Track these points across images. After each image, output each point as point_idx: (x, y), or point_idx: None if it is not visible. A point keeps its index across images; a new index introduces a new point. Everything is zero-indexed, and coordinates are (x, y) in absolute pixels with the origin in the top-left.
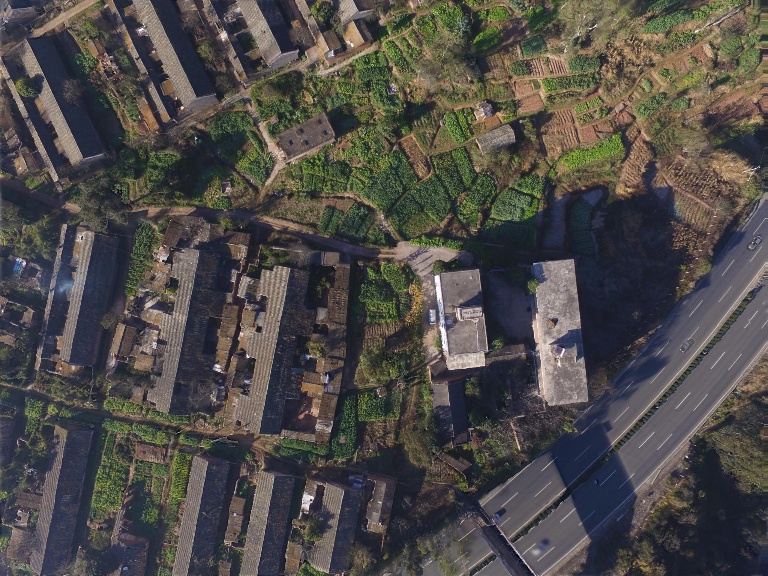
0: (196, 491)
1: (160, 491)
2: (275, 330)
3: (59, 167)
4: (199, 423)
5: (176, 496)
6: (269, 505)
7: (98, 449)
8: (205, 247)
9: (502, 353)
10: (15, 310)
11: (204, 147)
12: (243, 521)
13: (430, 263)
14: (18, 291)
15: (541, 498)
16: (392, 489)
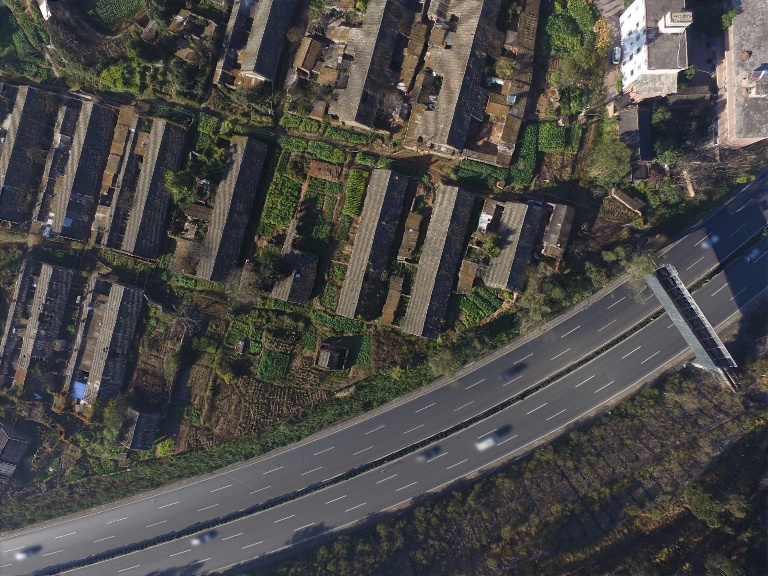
0: (376, 201)
1: (332, 209)
2: (468, 43)
3: None
4: (376, 143)
5: (350, 212)
6: (451, 216)
7: (271, 166)
8: None
9: (686, 92)
10: (197, 24)
11: None
12: (418, 238)
13: (615, 5)
14: (199, 7)
15: (693, 272)
16: (572, 213)
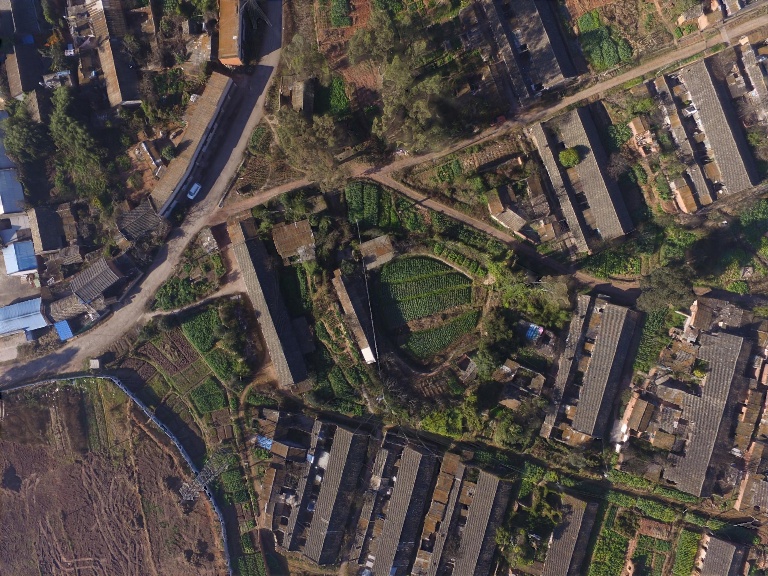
0: (717, 573)
1: (661, 567)
2: None
3: (590, 239)
4: (706, 503)
5: (683, 574)
6: None
7: (599, 520)
8: (736, 332)
9: None
10: (524, 375)
11: (728, 230)
12: None
13: None
14: (524, 356)
15: None
16: None
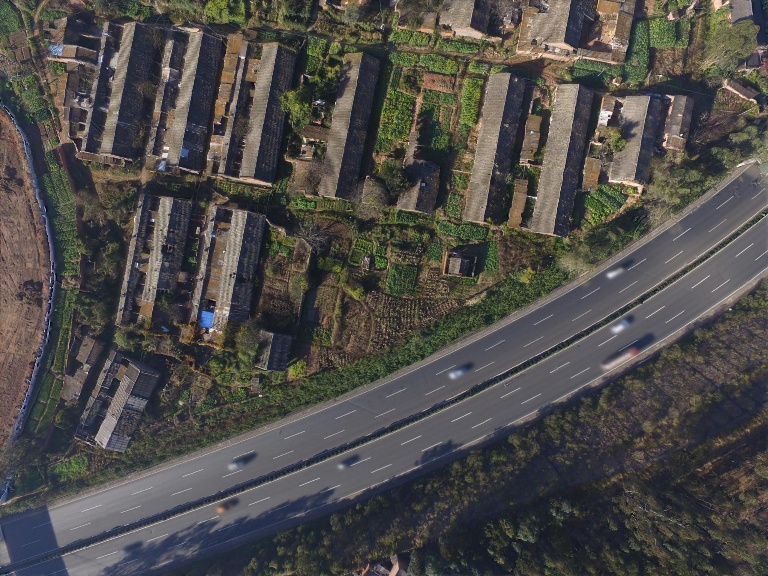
0: (496, 105)
1: (449, 120)
2: None
3: None
4: (488, 51)
5: (468, 120)
6: (574, 112)
7: (384, 82)
8: None
9: None
10: None
11: None
12: (539, 140)
13: None
14: None
15: None
16: (691, 103)
